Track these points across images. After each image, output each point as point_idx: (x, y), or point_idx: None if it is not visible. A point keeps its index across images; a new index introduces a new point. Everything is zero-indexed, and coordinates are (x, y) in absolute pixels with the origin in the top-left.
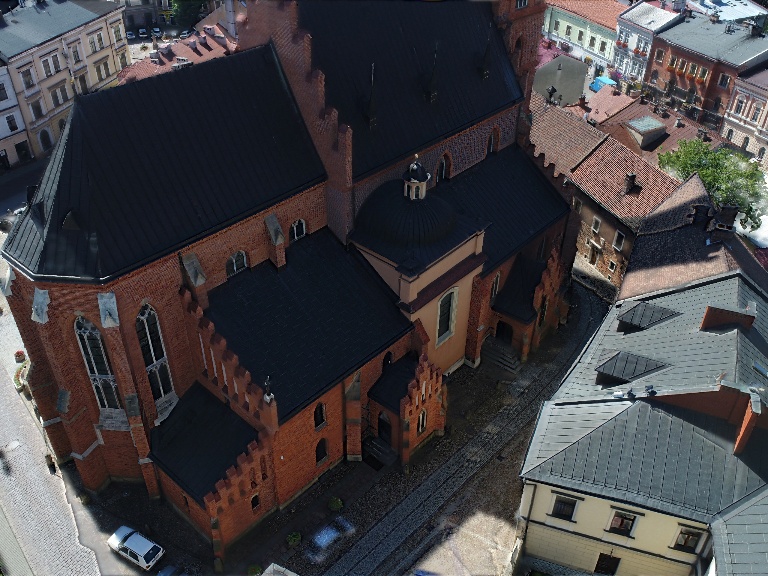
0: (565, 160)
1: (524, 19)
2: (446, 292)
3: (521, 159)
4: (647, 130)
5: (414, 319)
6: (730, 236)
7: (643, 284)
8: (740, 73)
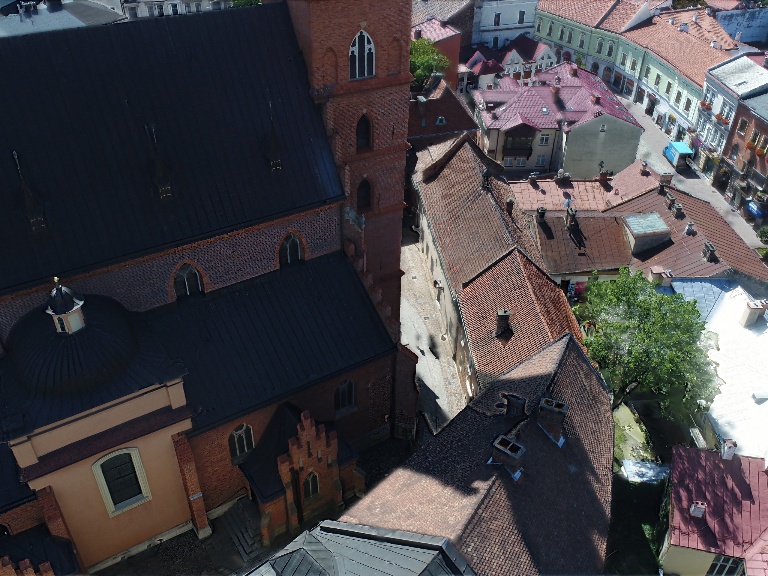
0: (469, 268)
1: (368, 93)
2: (107, 454)
3: (345, 272)
4: (642, 233)
5: (40, 486)
6: (512, 461)
7: (388, 497)
8: None
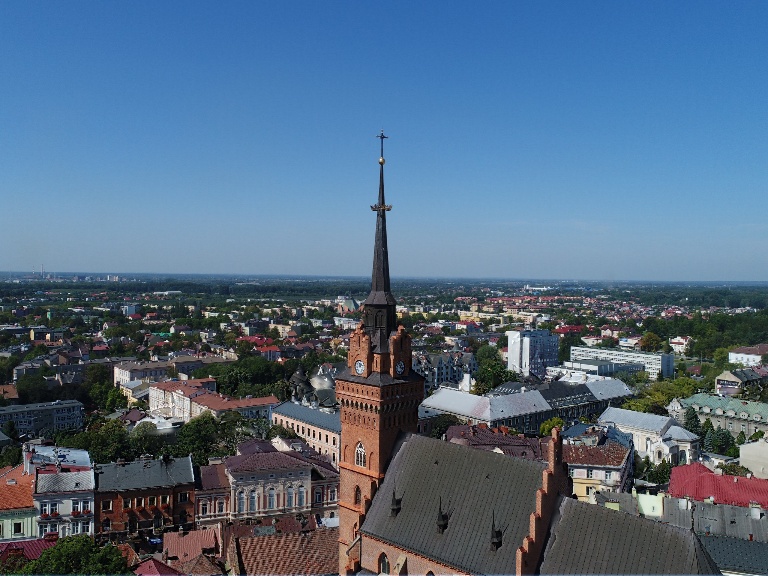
0: None
1: None
2: None
3: None
4: None
5: None
6: None
7: None
8: (195, 487)
